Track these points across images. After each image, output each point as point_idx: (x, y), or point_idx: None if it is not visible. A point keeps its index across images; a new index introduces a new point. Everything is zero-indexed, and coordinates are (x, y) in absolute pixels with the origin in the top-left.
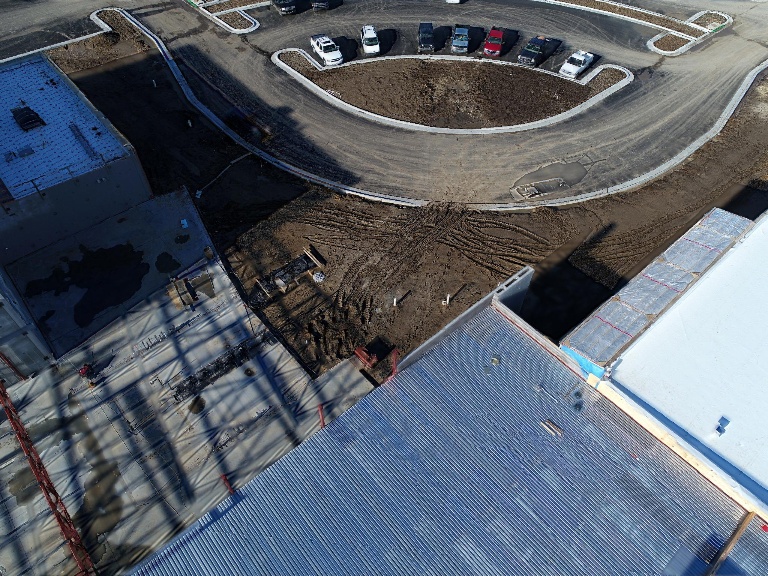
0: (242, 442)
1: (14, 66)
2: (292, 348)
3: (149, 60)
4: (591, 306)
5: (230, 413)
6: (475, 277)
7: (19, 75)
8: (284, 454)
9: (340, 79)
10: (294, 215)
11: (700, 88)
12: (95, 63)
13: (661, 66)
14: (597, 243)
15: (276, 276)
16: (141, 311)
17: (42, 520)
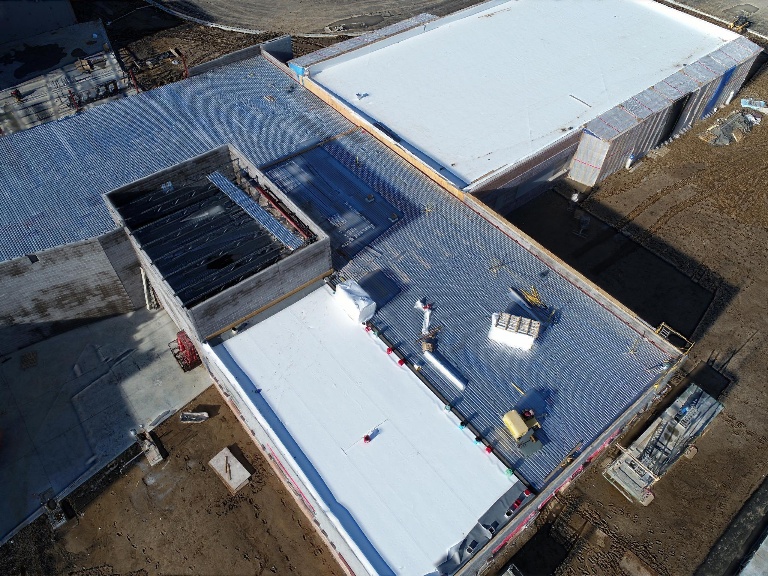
0: None
1: None
2: None
3: None
4: None
5: None
6: None
7: None
8: None
9: None
10: (170, 34)
11: None
12: None
13: None
14: None
15: (147, 60)
16: (57, 73)
17: None
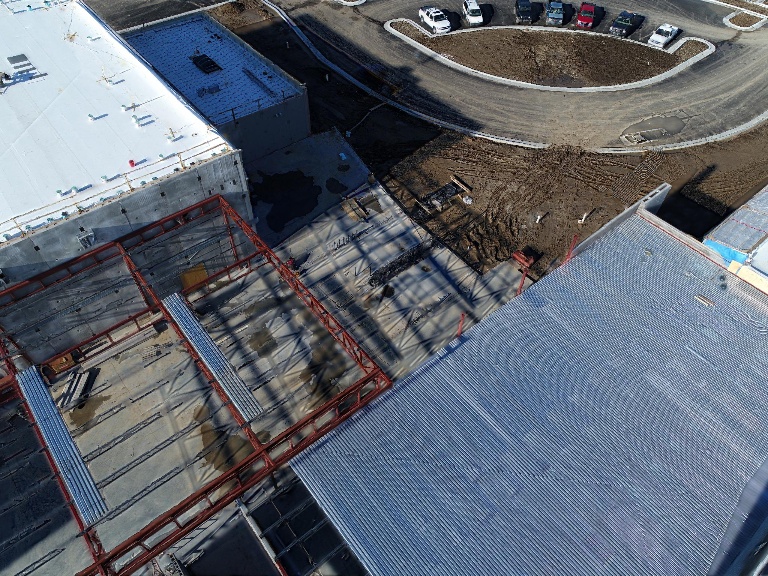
0: (432, 318)
1: (180, 23)
2: (456, 252)
3: (276, 26)
4: (707, 227)
5: (417, 298)
6: (602, 203)
7: (186, 30)
8: (468, 328)
9: (451, 45)
10: (435, 152)
11: None
12: (229, 28)
13: (739, 39)
14: (704, 179)
15: (432, 198)
16: (323, 221)
17: (282, 368)
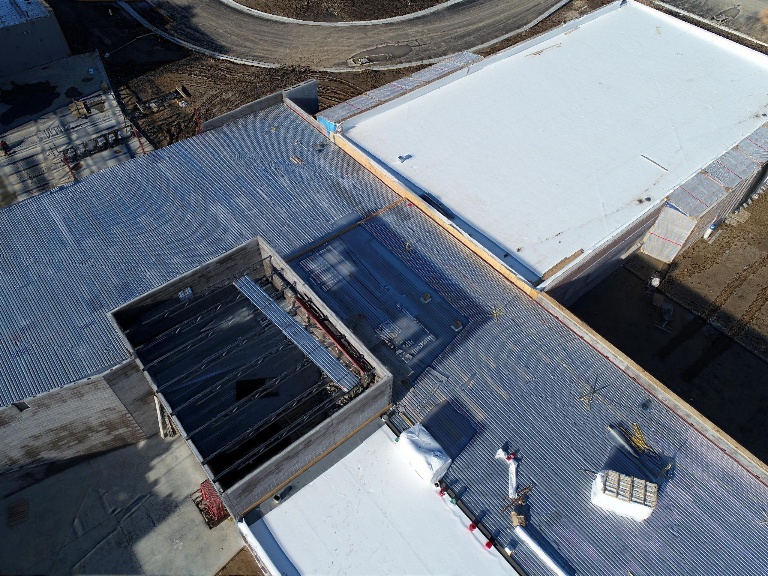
0: None
1: None
2: (152, 141)
3: None
4: None
5: None
6: None
7: None
8: None
9: None
10: (176, 69)
11: (529, 1)
12: None
13: None
14: None
15: (151, 102)
16: (49, 118)
17: None
